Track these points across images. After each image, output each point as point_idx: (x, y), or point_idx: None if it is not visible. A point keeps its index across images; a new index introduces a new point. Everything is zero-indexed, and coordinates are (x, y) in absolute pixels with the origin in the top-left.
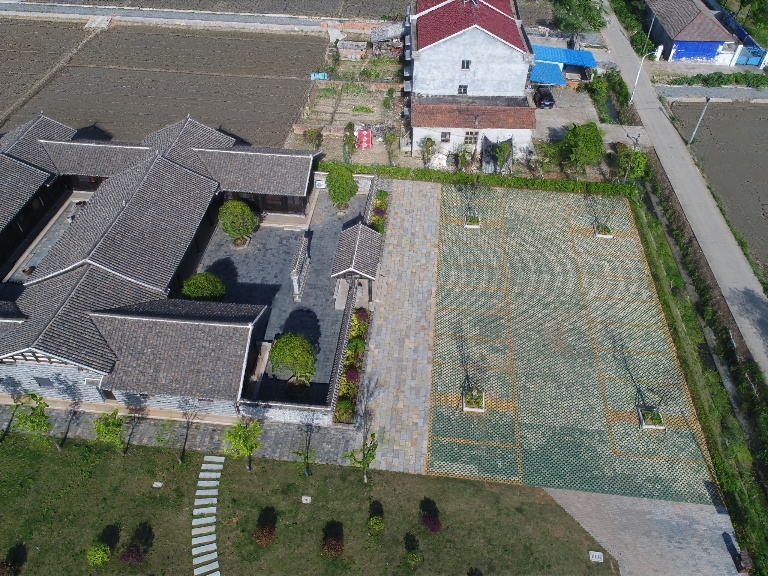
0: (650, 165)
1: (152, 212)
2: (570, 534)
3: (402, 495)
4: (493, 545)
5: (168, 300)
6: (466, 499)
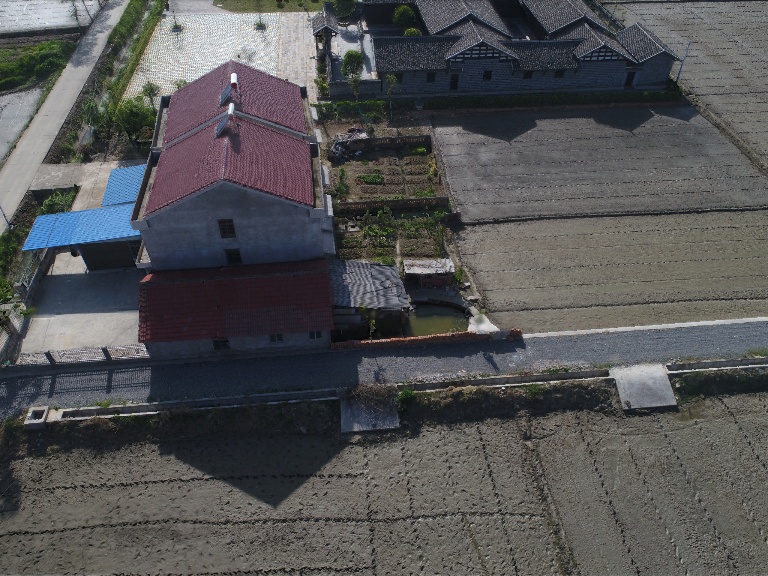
0: (60, 153)
1: (447, 5)
2: (228, 7)
3: (291, 8)
4: (257, 3)
5: (412, 0)
6: (266, 9)
